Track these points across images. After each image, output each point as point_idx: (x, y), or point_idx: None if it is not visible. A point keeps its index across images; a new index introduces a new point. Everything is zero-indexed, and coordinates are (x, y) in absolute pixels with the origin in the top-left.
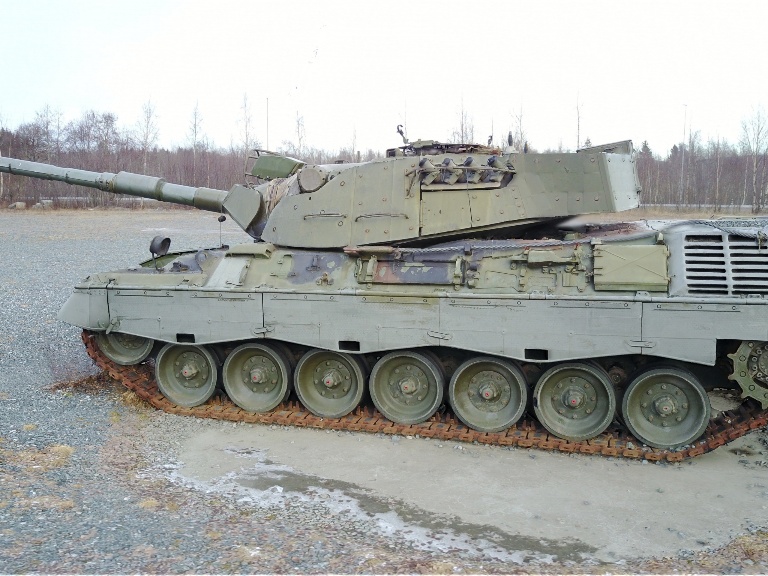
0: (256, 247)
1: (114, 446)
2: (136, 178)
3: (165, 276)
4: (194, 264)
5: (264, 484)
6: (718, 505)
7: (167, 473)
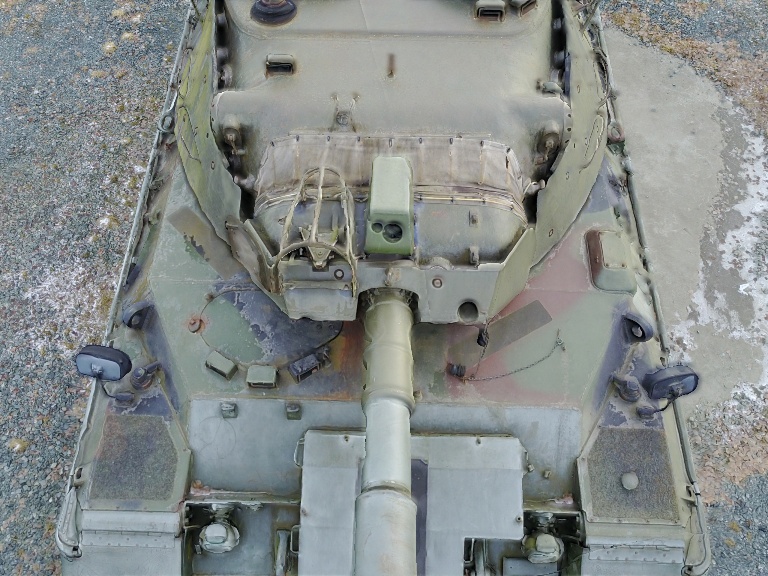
0: (628, 246)
1: (761, 462)
2: (411, 567)
3: (662, 398)
4: (614, 365)
5: (742, 302)
6: (615, 54)
7: (767, 389)
